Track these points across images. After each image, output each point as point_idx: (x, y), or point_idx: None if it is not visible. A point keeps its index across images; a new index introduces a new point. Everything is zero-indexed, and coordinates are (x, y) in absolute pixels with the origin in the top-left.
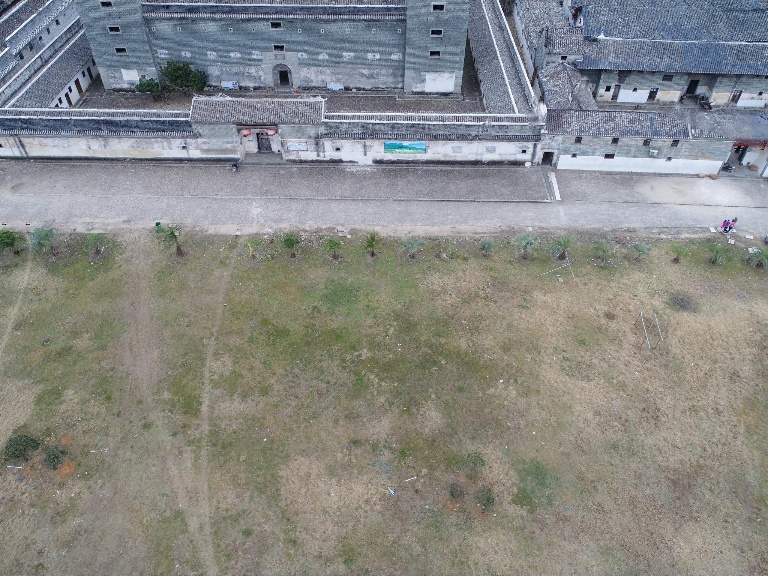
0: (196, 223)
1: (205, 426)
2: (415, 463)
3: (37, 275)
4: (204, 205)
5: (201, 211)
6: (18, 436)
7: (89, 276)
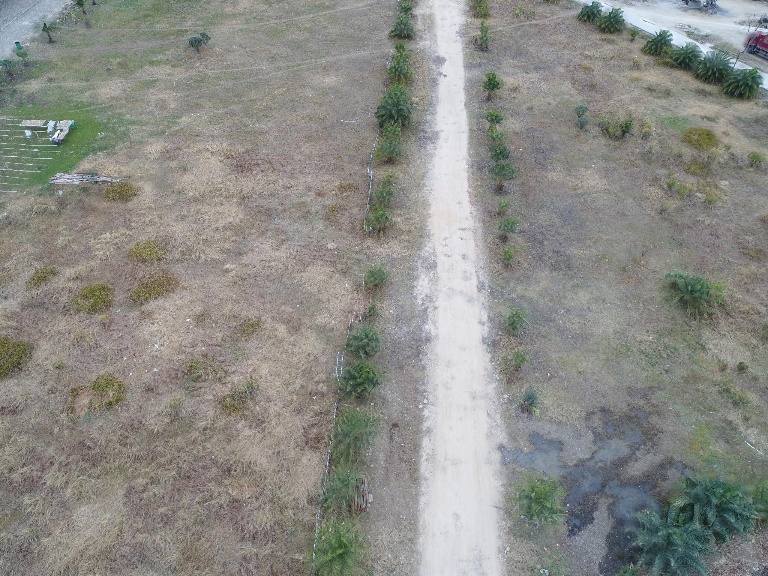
0: (22, 39)
1: (197, 27)
2: None
3: (35, 82)
4: (1, 38)
5: (8, 38)
6: (191, 38)
7: (52, 66)
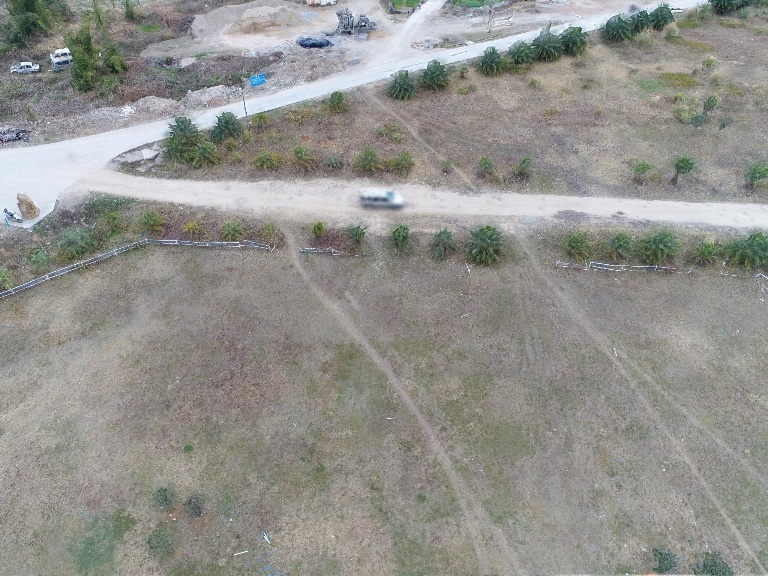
0: None
1: None
2: (231, 575)
3: None
4: None
5: None
6: None
7: None
